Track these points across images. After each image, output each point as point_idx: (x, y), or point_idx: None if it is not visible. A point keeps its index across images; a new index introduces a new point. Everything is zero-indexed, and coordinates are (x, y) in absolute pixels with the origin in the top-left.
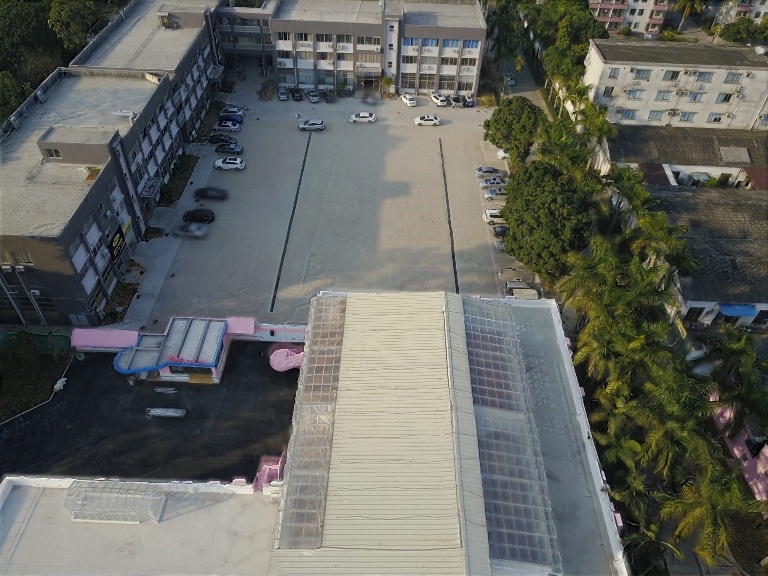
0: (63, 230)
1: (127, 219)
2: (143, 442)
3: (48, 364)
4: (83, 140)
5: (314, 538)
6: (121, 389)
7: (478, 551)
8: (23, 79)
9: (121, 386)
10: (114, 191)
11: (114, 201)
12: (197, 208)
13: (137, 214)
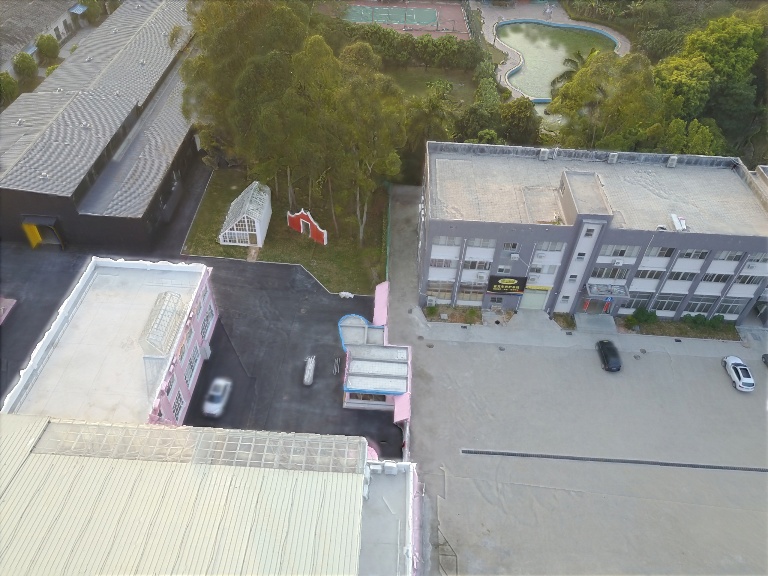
0: (441, 219)
1: (547, 284)
2: (280, 360)
3: (370, 283)
4: (582, 197)
5: (45, 448)
6: None
7: None
8: (763, 160)
9: None
10: (552, 252)
11: (539, 257)
12: (628, 353)
13: (566, 293)
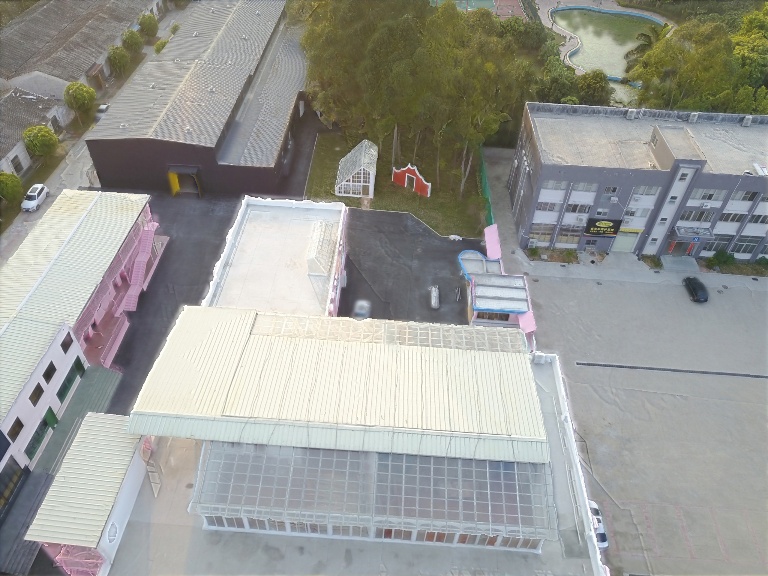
0: (552, 164)
1: (639, 227)
2: (407, 289)
3: (474, 229)
4: (676, 146)
5: (260, 332)
6: (456, 269)
7: (217, 430)
8: None
9: (458, 269)
10: (647, 196)
11: (635, 200)
12: (712, 288)
13: (656, 235)
